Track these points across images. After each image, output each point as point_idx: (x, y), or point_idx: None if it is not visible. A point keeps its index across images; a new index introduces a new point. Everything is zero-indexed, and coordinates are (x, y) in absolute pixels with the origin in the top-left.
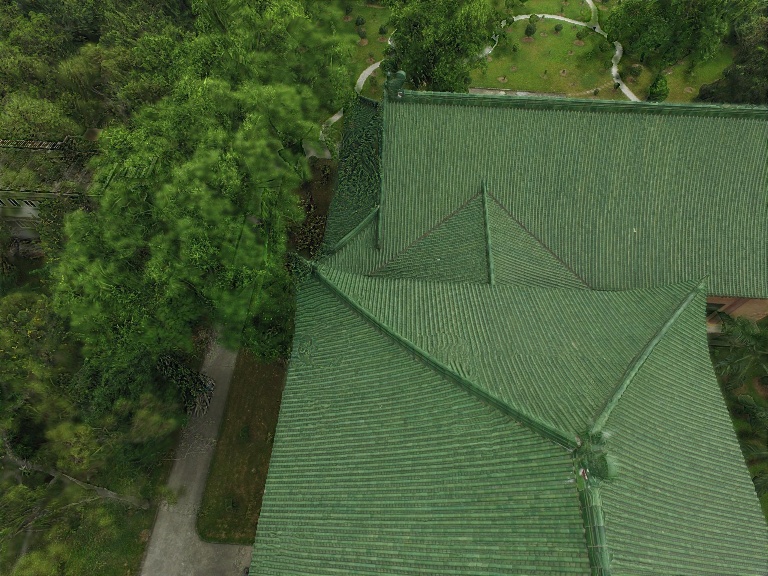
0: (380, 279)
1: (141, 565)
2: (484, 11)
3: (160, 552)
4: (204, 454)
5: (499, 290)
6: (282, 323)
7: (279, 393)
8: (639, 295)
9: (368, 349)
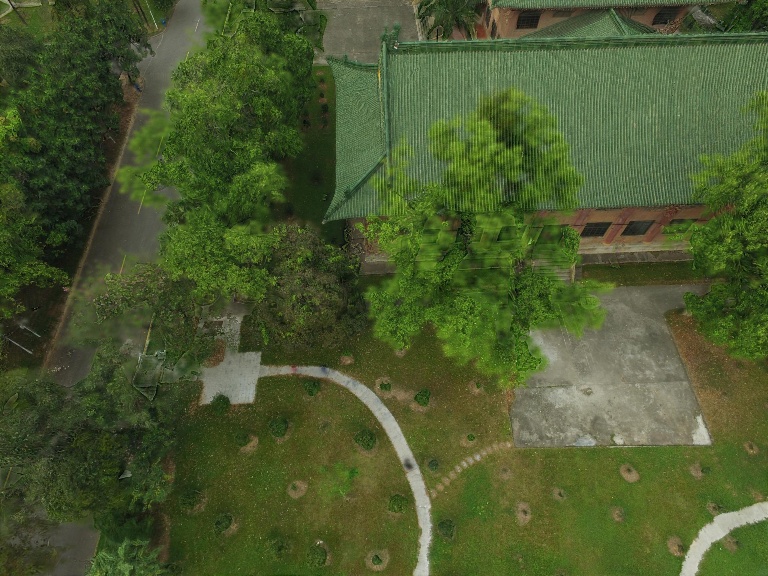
0: (682, 2)
1: None
2: (764, 219)
3: None
4: None
5: (611, 1)
6: None
7: None
8: (531, 1)
9: None
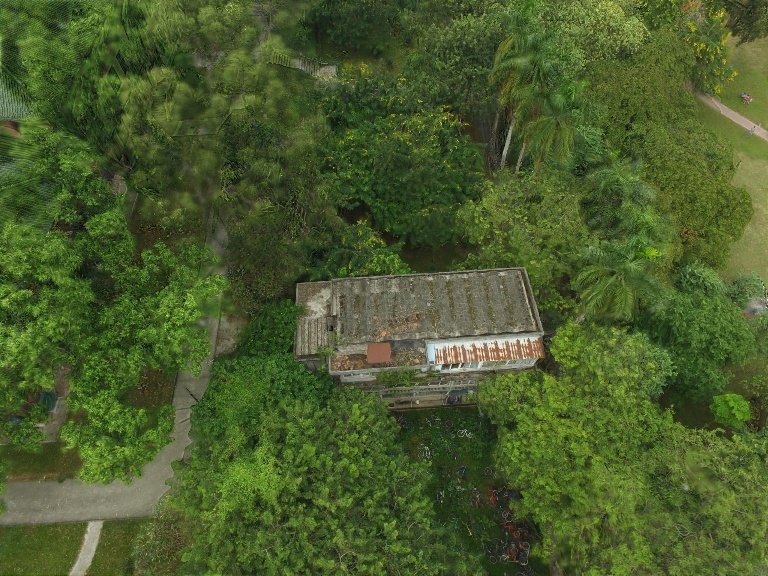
0: None
1: None
2: None
3: None
4: None
5: None
6: None
7: (173, 200)
8: None
9: (3, 49)
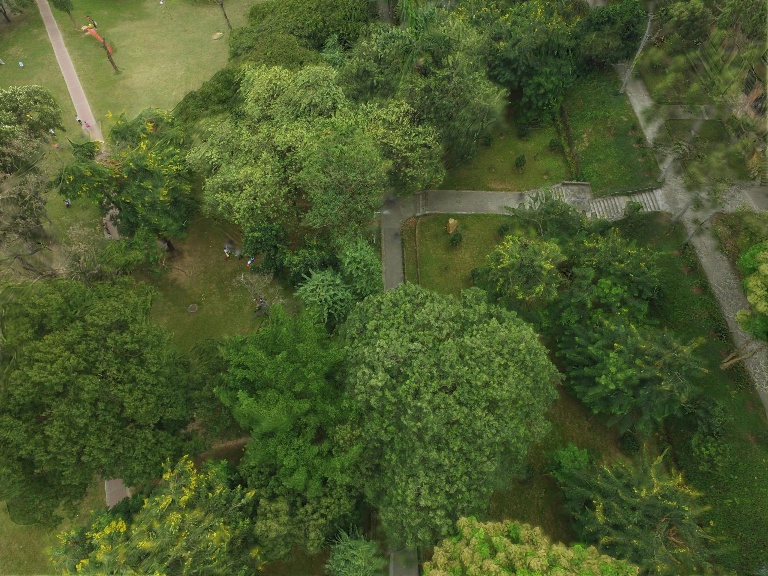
0: None
1: (634, 111)
2: None
3: (640, 108)
4: (635, 77)
5: None
6: (641, 31)
7: None
8: None
9: None
